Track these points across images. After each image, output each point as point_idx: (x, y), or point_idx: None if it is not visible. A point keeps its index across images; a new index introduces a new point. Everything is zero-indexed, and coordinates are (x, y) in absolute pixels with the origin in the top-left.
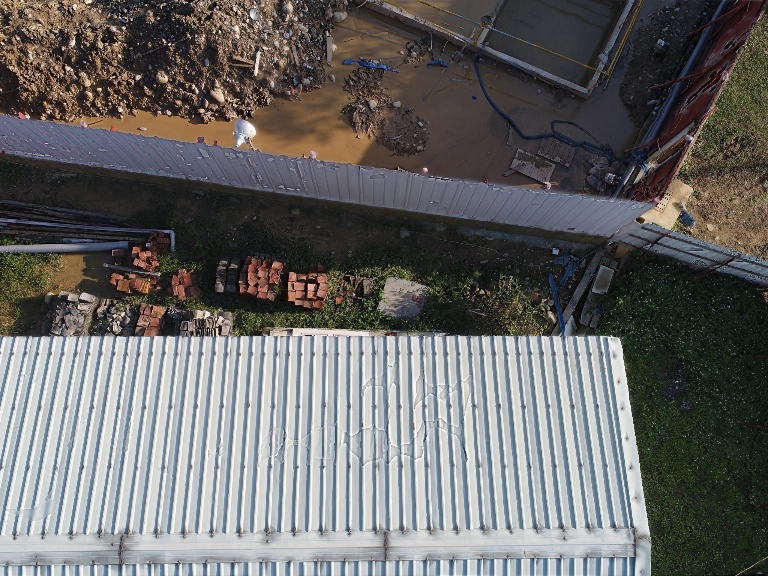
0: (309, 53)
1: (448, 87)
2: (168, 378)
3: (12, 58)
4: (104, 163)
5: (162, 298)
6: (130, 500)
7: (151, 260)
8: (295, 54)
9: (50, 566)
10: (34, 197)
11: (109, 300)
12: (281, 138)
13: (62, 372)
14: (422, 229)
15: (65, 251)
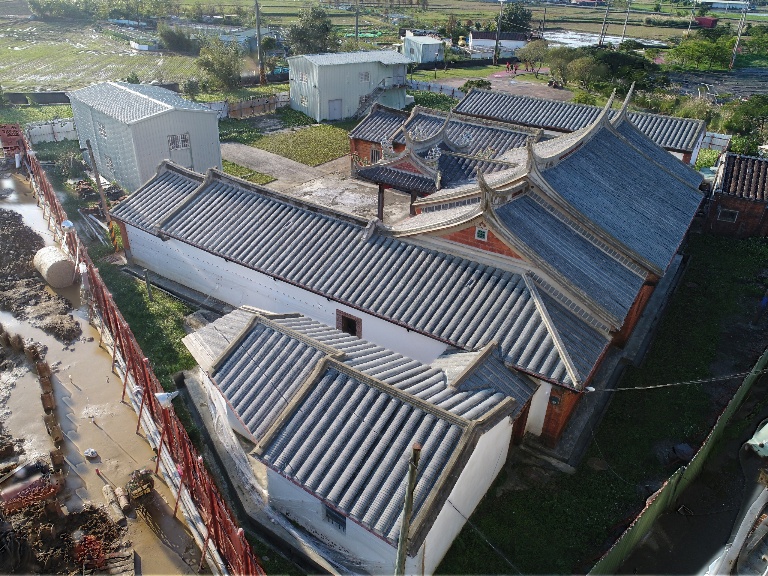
0: None
1: None
2: None
3: None
4: None
5: None
6: None
7: None
8: None
9: None
10: None
11: None
12: (20, 205)
13: None
14: None
15: None
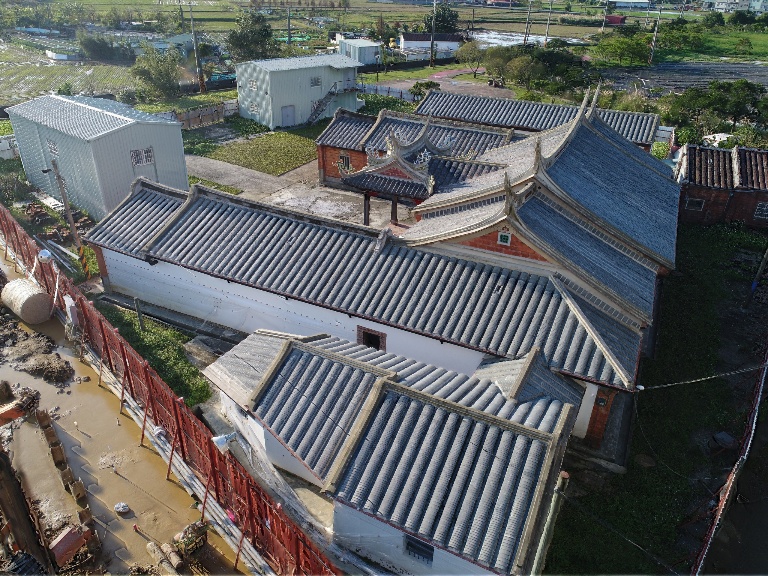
0: None
1: None
2: None
3: None
4: None
5: None
6: None
7: None
8: None
9: None
10: None
11: None
12: None
13: None
14: None
15: None
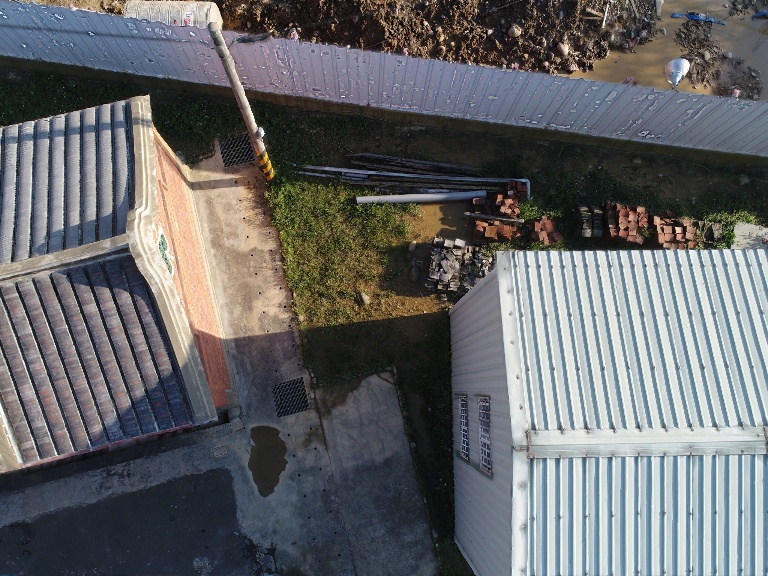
0: (642, 7)
1: (761, 40)
2: (749, 287)
3: (383, 13)
4: (470, 114)
5: (525, 244)
6: (757, 396)
7: (513, 208)
8: (634, 7)
9: (703, 456)
10: (386, 150)
11: (471, 247)
12: None
13: (650, 282)
14: (762, 176)
15: (425, 201)
